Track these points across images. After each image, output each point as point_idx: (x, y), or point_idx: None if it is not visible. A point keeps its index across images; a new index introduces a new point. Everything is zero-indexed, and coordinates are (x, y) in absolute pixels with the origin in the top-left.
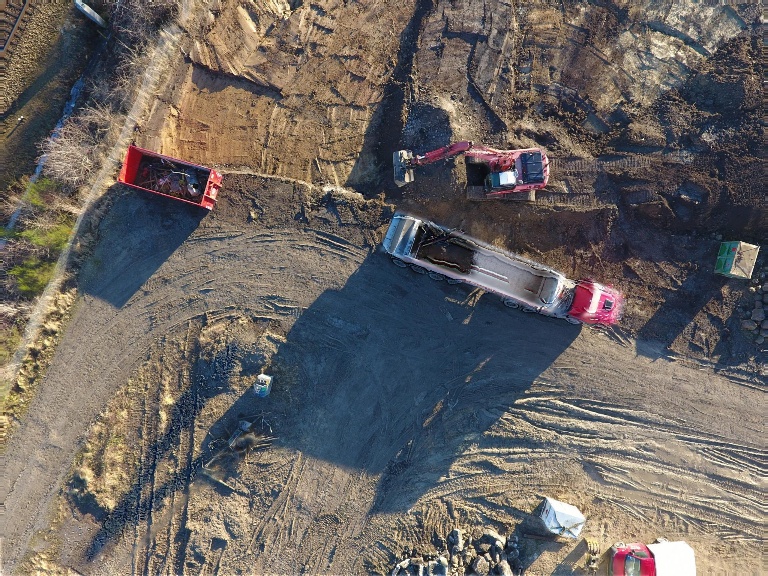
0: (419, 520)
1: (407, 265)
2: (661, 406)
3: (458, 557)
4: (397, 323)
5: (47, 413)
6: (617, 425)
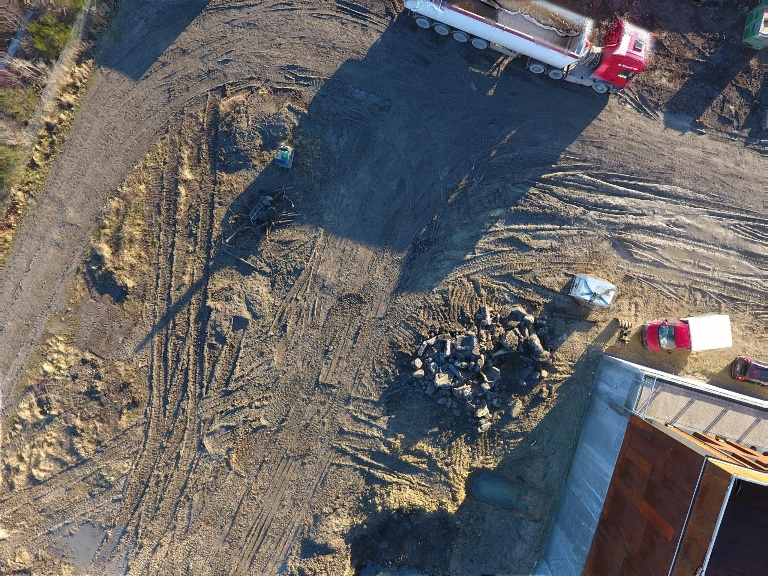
0: (445, 299)
1: (430, 25)
2: (691, 180)
3: (486, 333)
4: (420, 94)
5: (63, 190)
6: (646, 200)
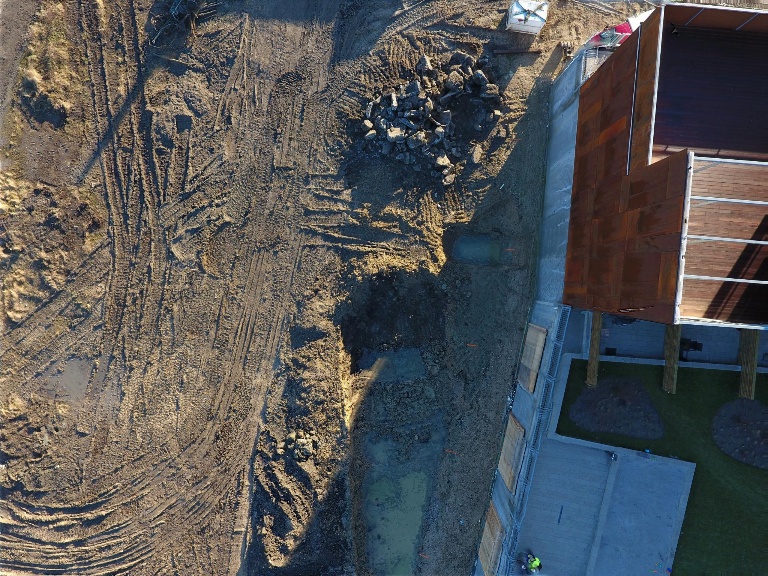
0: (383, 59)
1: None
2: None
3: (430, 81)
4: None
5: None
6: None
